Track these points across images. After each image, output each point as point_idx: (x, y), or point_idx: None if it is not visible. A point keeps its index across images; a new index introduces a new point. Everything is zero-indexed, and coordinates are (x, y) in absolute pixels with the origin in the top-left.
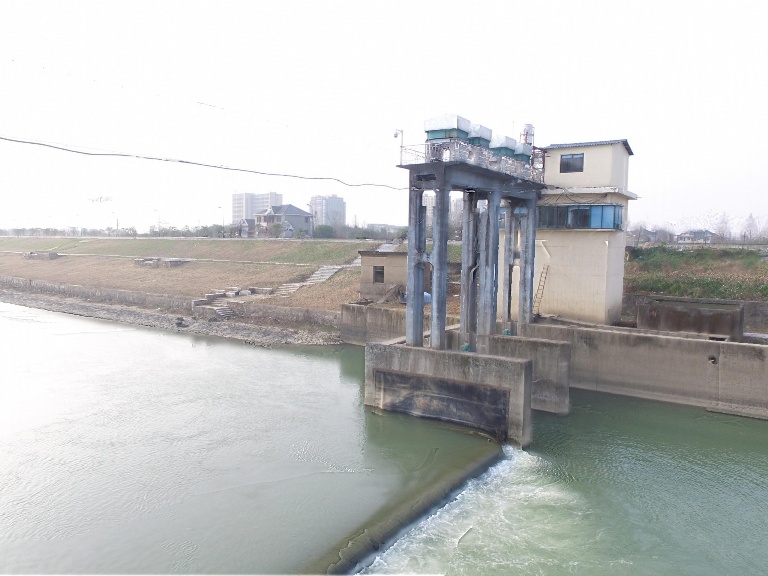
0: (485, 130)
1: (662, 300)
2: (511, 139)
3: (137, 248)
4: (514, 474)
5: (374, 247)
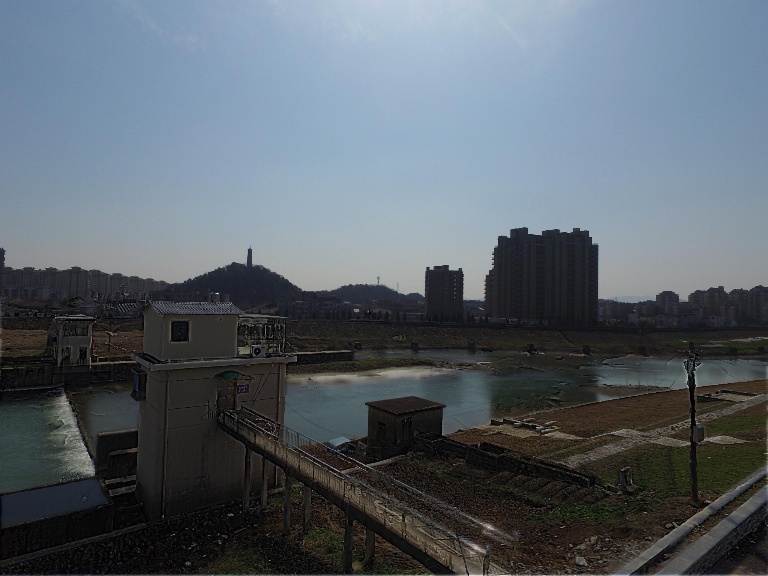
0: None
1: (99, 505)
2: None
3: None
4: (84, 470)
5: None
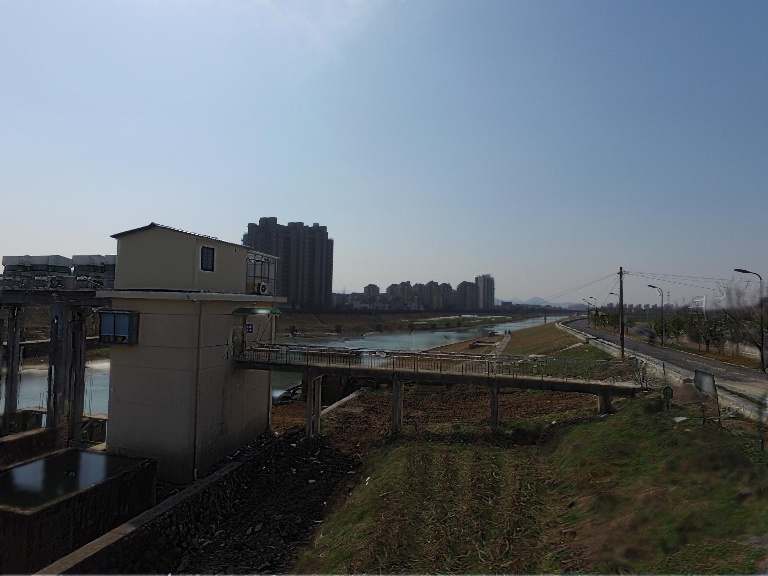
0: (40, 258)
1: None
2: (82, 256)
3: (531, 332)
4: None
5: (566, 345)
